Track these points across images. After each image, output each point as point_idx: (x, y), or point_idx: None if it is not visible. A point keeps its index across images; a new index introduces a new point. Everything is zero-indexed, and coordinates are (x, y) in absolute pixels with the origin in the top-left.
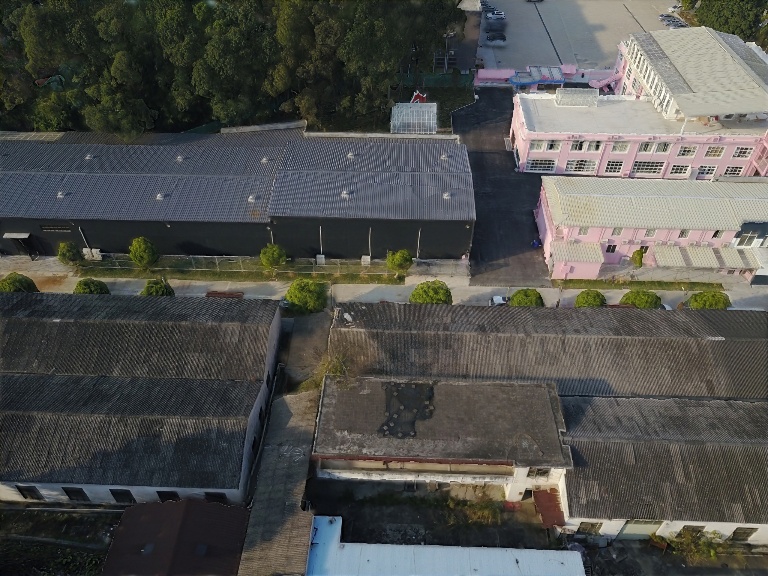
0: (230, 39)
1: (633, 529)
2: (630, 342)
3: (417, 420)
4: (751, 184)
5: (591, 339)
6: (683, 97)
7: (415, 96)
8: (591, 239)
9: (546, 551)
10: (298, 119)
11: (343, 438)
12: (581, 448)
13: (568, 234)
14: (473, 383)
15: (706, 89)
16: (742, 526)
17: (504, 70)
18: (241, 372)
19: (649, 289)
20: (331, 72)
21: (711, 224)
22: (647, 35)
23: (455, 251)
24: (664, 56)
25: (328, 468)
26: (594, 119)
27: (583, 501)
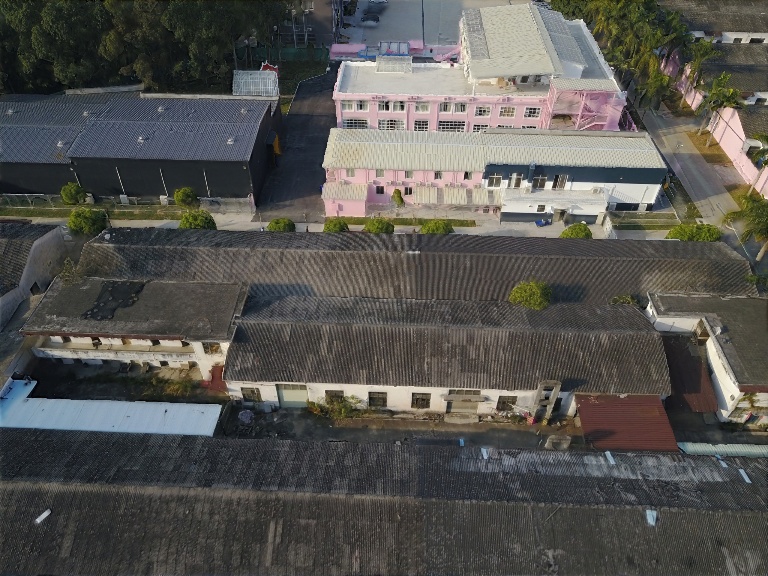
0: (62, 7)
1: (290, 396)
2: (339, 255)
3: (119, 307)
4: (513, 135)
5: (306, 253)
6: (478, 62)
7: (264, 66)
8: (359, 181)
9: (193, 404)
10: (139, 83)
11: (50, 320)
12: (247, 328)
13: (338, 176)
14: (181, 282)
15: (501, 55)
16: (372, 390)
17: (355, 45)
18: (0, 278)
19: (409, 225)
20: (160, 38)
21: (460, 166)
22: (477, 11)
23: (241, 191)
24: (481, 29)
25: (43, 347)
26: (404, 83)
27: (237, 368)
